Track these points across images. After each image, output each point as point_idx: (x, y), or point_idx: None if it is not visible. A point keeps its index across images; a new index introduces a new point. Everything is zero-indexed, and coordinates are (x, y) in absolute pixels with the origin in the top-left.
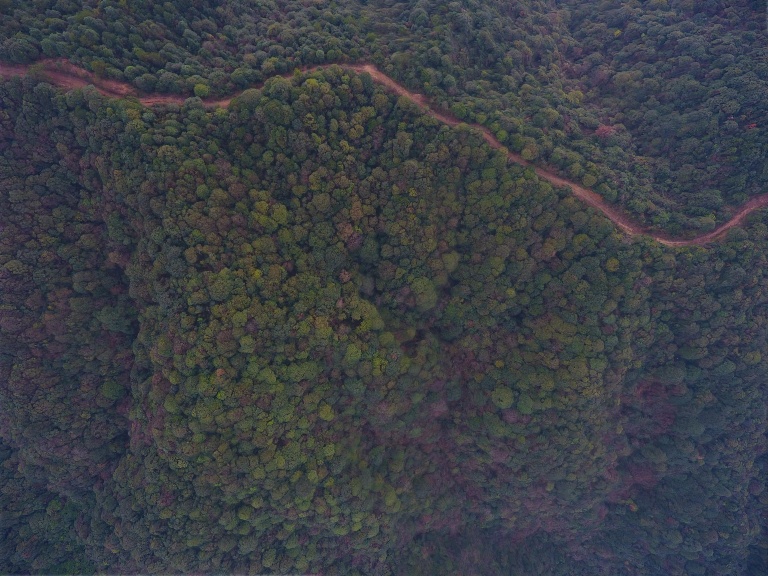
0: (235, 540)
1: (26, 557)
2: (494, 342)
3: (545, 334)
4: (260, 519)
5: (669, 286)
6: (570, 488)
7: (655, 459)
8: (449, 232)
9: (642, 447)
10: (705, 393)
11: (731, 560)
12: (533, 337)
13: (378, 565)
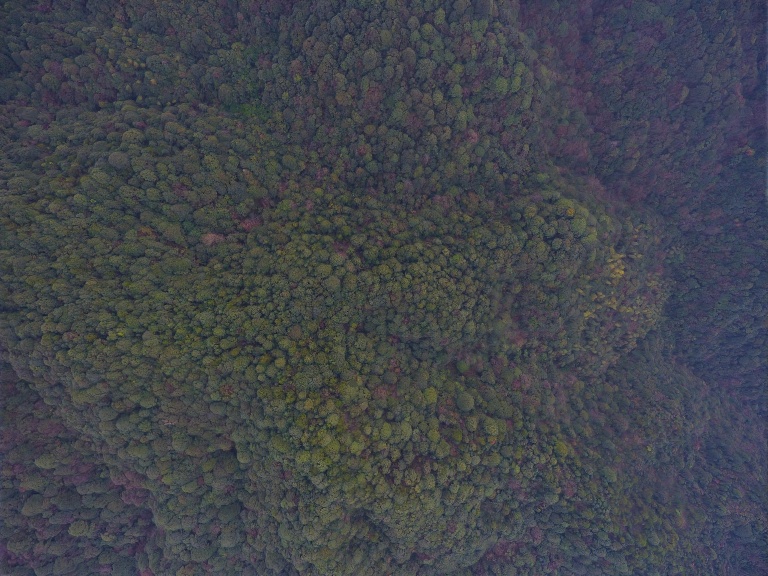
0: (416, 57)
1: (217, 76)
2: None
3: None
4: (439, 41)
5: None
6: (705, 90)
7: None
8: None
9: None
10: None
11: None
12: None
13: (521, 156)
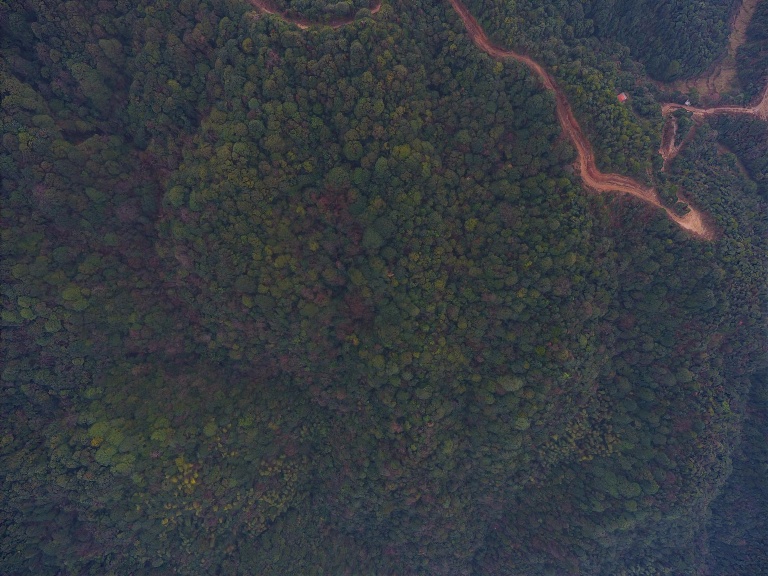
0: None
1: None
2: (181, 148)
3: (204, 125)
4: None
5: (304, 69)
6: (263, 301)
7: (354, 280)
8: (102, 15)
9: (347, 271)
10: (375, 198)
11: (429, 384)
12: (201, 133)
13: (74, 369)
